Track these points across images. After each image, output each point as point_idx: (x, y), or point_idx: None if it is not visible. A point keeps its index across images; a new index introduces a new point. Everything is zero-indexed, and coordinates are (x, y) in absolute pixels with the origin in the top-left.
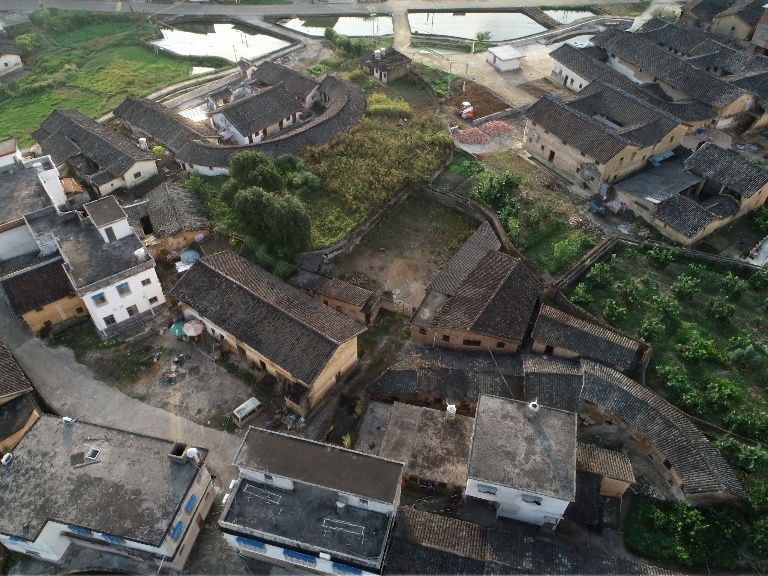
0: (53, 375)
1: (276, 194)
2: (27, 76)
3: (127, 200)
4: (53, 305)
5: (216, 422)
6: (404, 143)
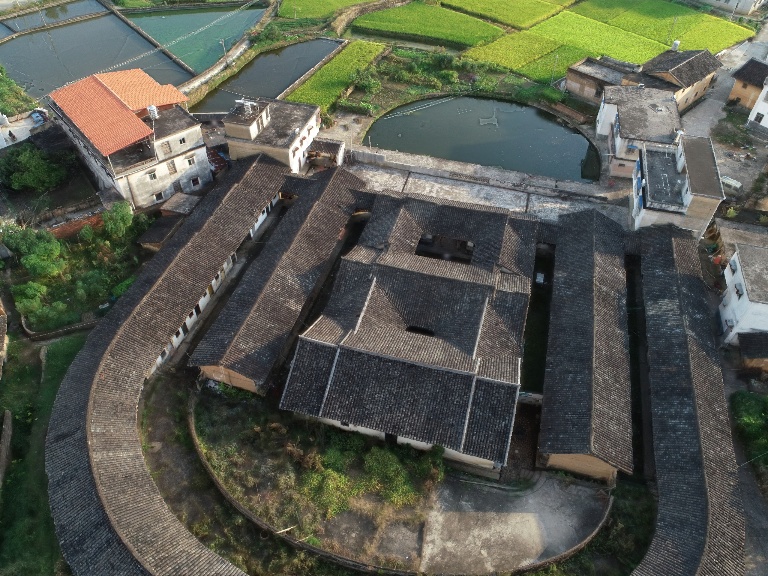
0: (703, 114)
1: None
2: None
3: None
4: (752, 91)
5: None
6: None
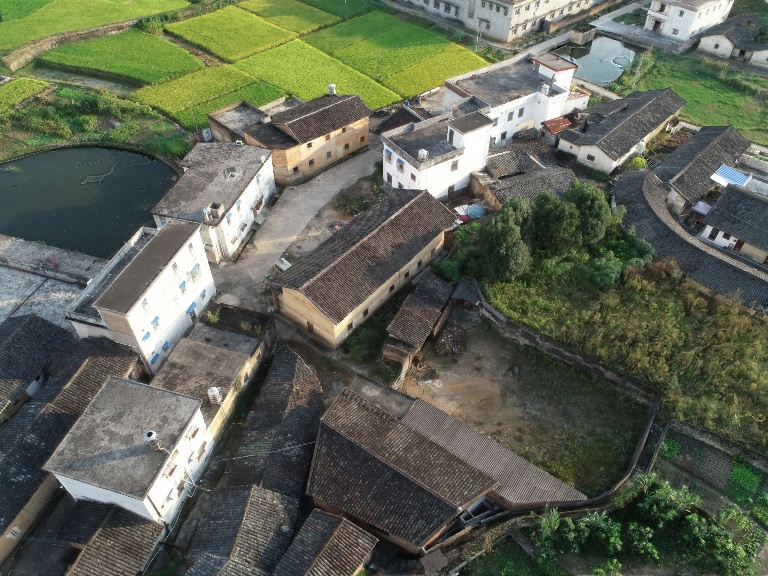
0: (347, 170)
1: (575, 250)
2: (760, 75)
3: (549, 159)
4: None
5: (286, 257)
6: (762, 384)
